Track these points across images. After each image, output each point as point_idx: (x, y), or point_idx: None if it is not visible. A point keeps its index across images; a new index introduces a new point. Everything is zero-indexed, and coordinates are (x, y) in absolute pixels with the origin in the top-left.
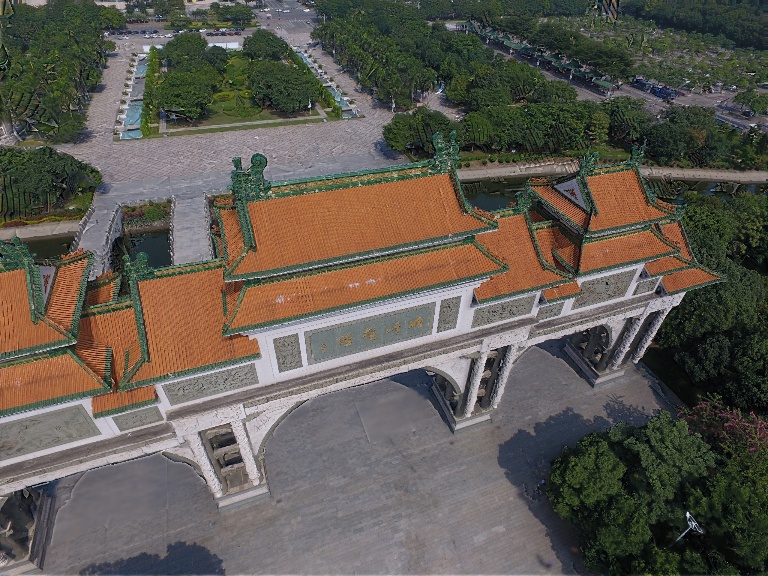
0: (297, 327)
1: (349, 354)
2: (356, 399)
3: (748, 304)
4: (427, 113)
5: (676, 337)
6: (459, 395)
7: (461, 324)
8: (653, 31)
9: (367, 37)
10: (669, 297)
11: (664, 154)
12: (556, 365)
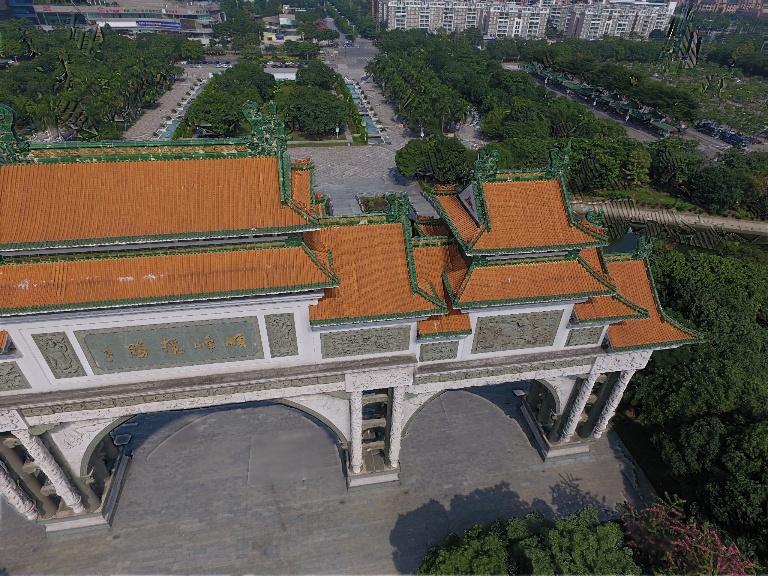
0: (60, 323)
1: (150, 368)
2: (255, 431)
3: (765, 382)
4: (441, 139)
5: (660, 412)
6: (347, 444)
7: (305, 351)
8: (734, 76)
9: (412, 69)
10: (625, 355)
11: (715, 201)
12: (506, 426)
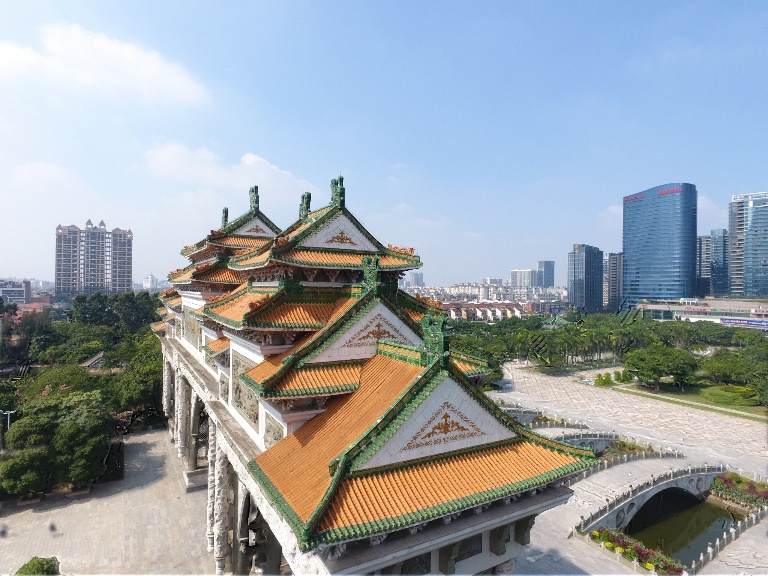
0: None
1: None
2: None
3: None
4: None
5: None
6: None
7: None
8: None
9: None
10: None
11: None
12: None
